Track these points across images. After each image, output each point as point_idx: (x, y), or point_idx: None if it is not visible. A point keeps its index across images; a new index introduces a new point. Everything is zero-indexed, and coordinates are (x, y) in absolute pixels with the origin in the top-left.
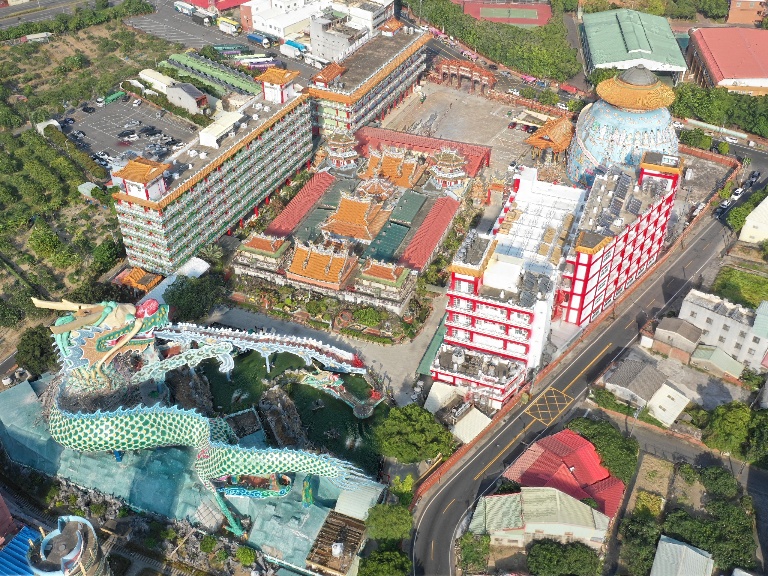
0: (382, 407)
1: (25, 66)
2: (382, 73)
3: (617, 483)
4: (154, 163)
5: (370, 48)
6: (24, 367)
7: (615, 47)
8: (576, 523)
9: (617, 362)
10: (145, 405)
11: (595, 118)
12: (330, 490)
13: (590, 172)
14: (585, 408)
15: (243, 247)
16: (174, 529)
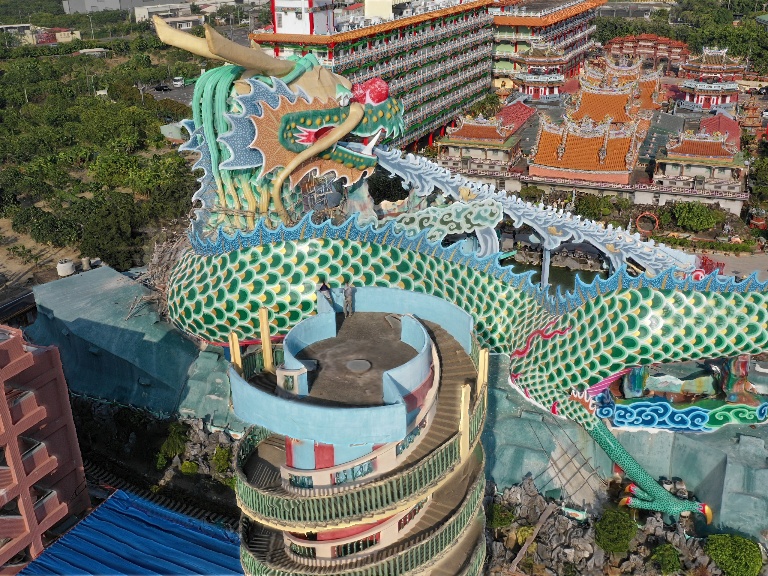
0: None
1: None
2: (567, 12)
3: None
4: None
5: (536, 2)
6: (99, 253)
7: None
8: None
9: None
10: None
11: None
12: None
13: None
14: None
15: (447, 140)
16: None
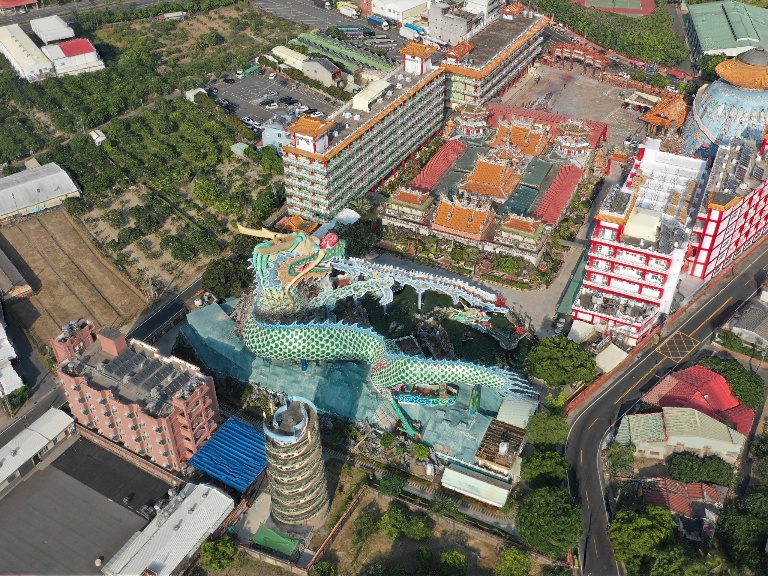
0: (525, 341)
1: (165, 41)
2: (507, 52)
3: (747, 410)
4: (320, 120)
5: (493, 29)
6: (211, 292)
7: (723, 35)
8: (715, 437)
9: None
10: None
11: (713, 96)
12: (490, 403)
13: (706, 147)
14: (711, 350)
15: (391, 200)
16: (355, 428)
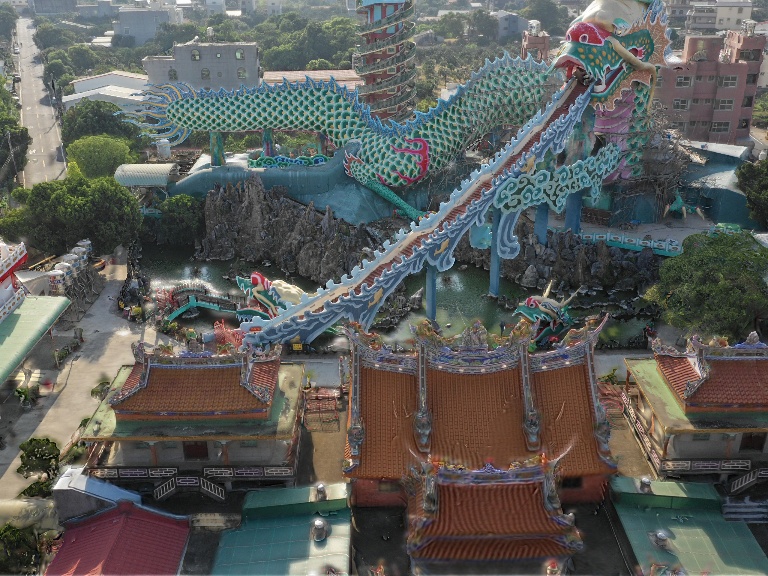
0: None
1: None
2: None
3: None
4: None
5: None
6: None
7: None
8: None
9: None
10: None
11: None
12: None
13: None
14: None
15: None
16: None
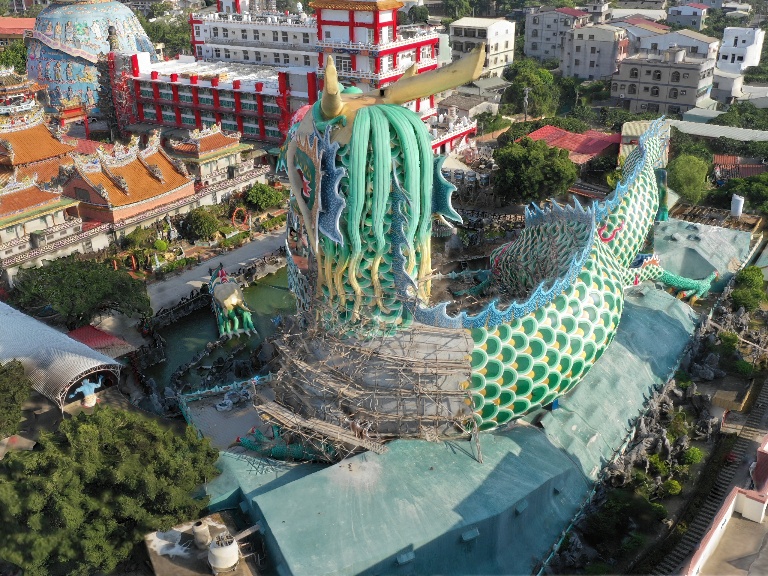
0: None
1: None
2: None
3: (593, 130)
4: None
5: None
6: (175, 516)
7: None
8: None
9: None
10: None
11: (73, 21)
12: None
13: None
14: None
15: None
16: None
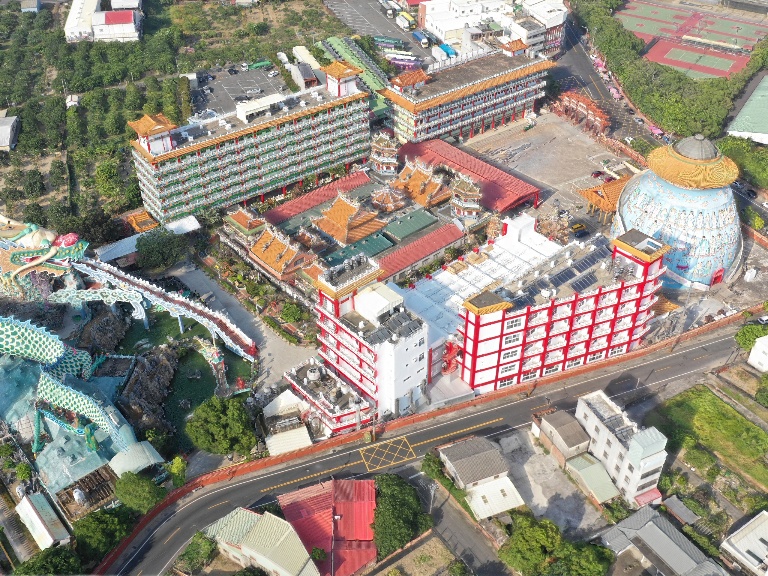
0: (244, 397)
1: (218, 25)
2: (468, 90)
3: (370, 549)
4: (166, 122)
5: (479, 63)
6: None
7: (767, 117)
8: (281, 564)
9: (491, 438)
10: (61, 324)
11: (639, 183)
12: None
13: None
14: (419, 469)
15: (229, 217)
16: None
